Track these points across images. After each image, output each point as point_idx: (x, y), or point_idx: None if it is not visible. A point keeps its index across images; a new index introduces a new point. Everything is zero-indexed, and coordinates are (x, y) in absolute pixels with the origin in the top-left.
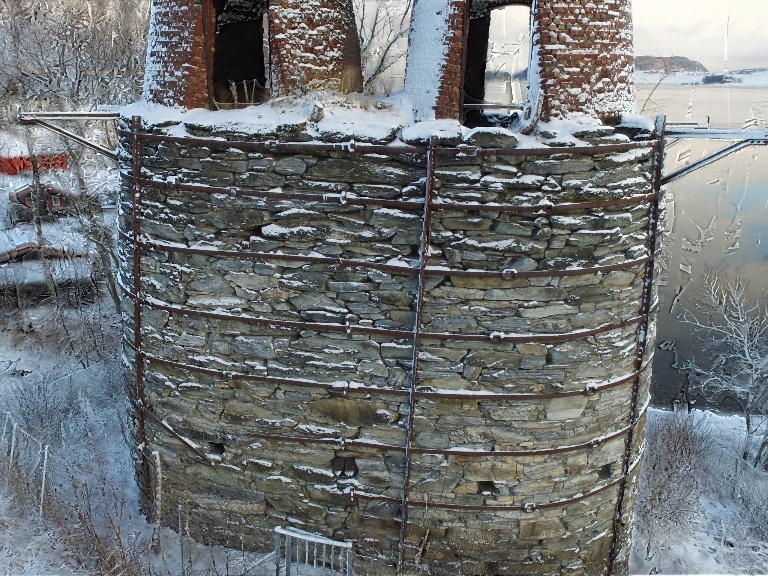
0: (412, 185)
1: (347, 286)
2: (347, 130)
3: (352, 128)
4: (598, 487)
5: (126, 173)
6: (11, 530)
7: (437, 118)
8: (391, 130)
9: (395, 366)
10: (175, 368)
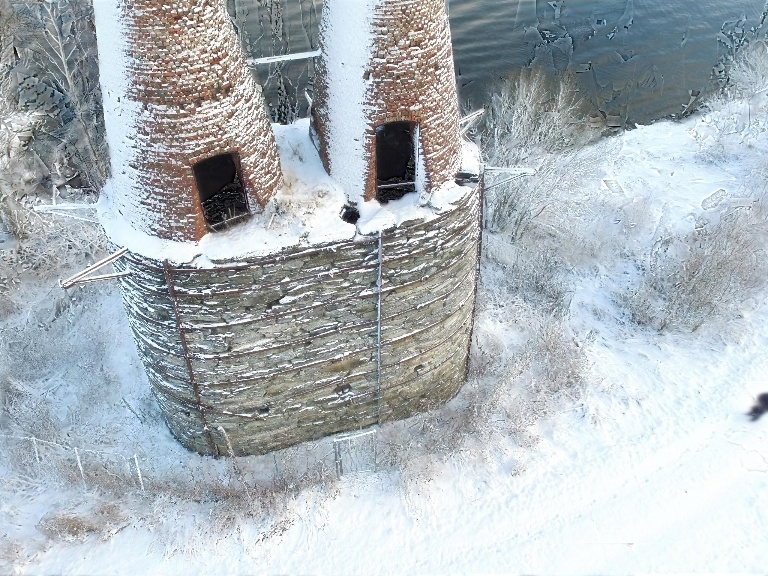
0: (370, 255)
1: (337, 312)
2: (329, 239)
3: (331, 237)
4: (464, 339)
5: (156, 290)
6: (131, 507)
7: (365, 201)
8: None
9: (368, 337)
10: (229, 385)
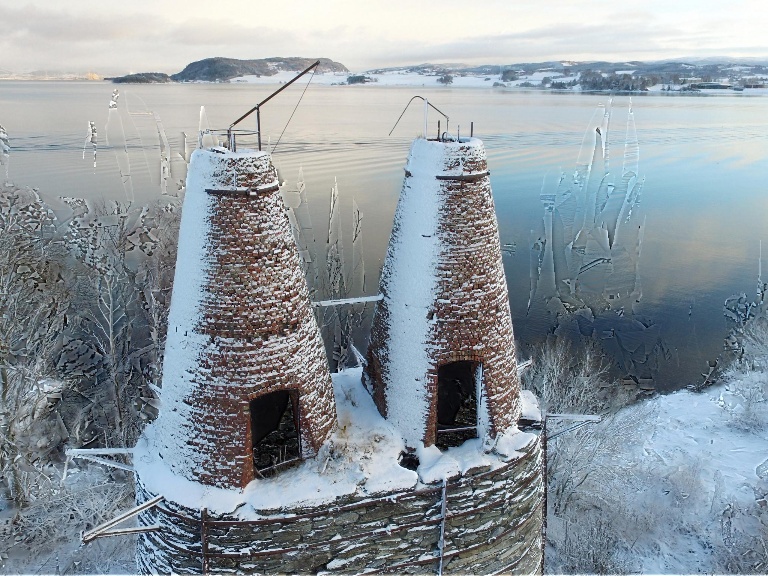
0: (432, 509)
1: None
2: (388, 488)
3: (391, 485)
4: None
5: (186, 548)
6: None
7: (425, 446)
8: None
9: None
10: None
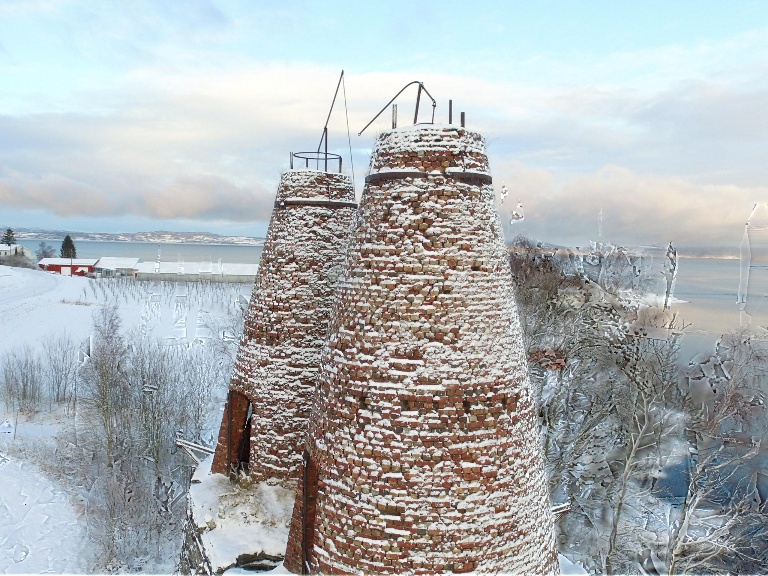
0: None
1: None
2: (208, 550)
3: None
4: None
5: None
6: None
7: (285, 564)
8: (218, 568)
9: None
10: None
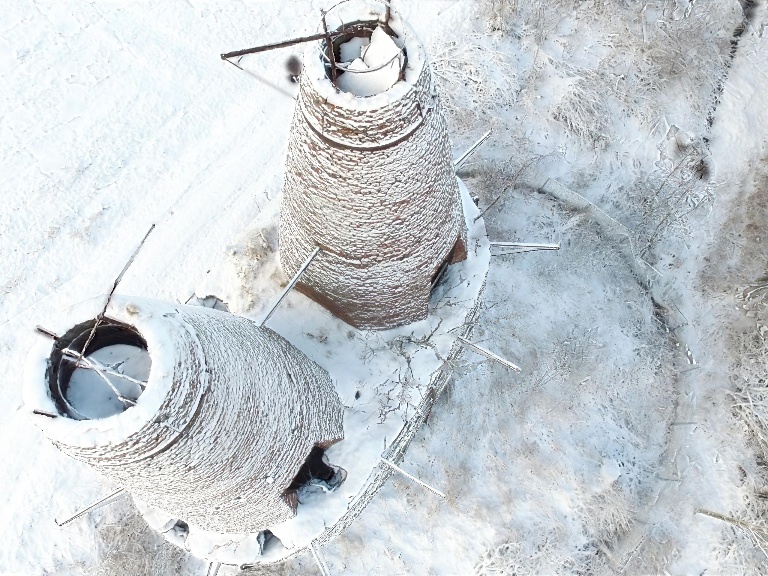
0: None
1: None
2: None
3: None
4: None
5: None
6: None
7: None
8: None
9: None
10: None
